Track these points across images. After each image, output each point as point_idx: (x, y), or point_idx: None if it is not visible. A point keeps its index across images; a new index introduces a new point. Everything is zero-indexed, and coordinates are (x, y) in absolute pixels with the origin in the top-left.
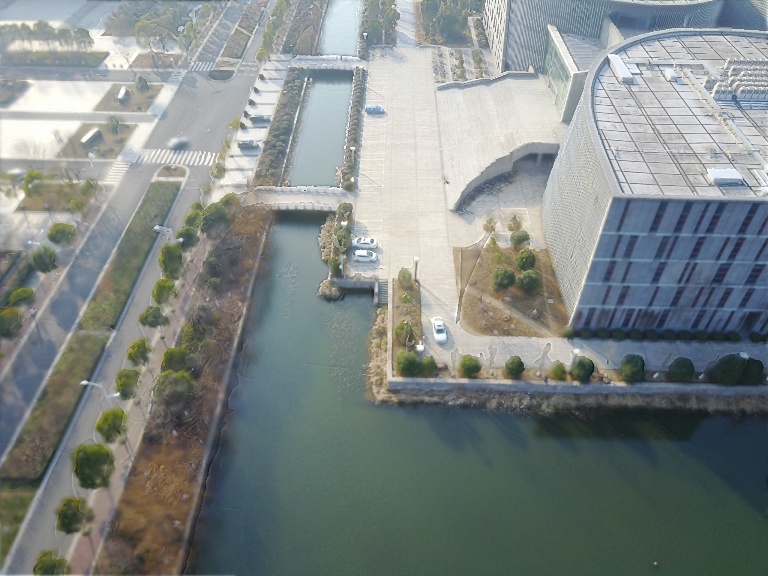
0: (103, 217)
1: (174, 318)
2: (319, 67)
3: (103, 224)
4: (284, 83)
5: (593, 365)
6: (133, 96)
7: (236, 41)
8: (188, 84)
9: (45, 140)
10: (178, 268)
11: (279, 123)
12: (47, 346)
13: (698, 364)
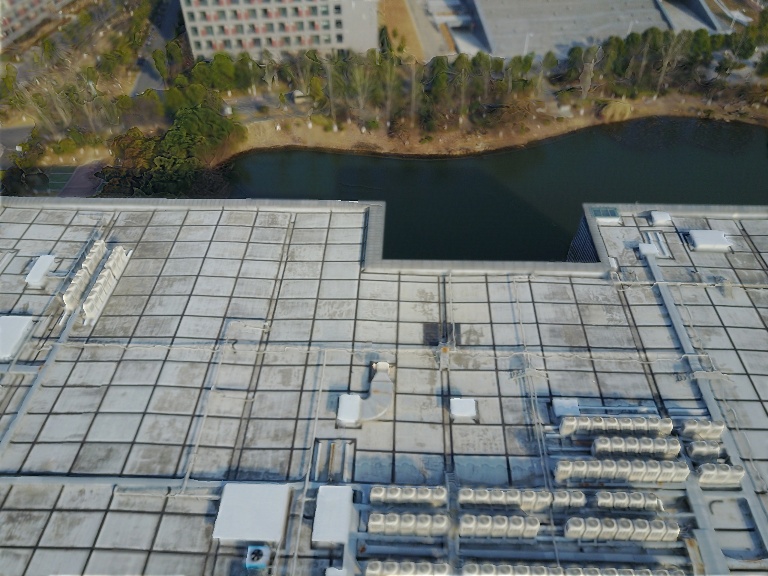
0: None
1: None
2: None
3: None
4: None
5: None
6: None
7: None
8: None
9: None
10: None
11: None
12: None
13: None
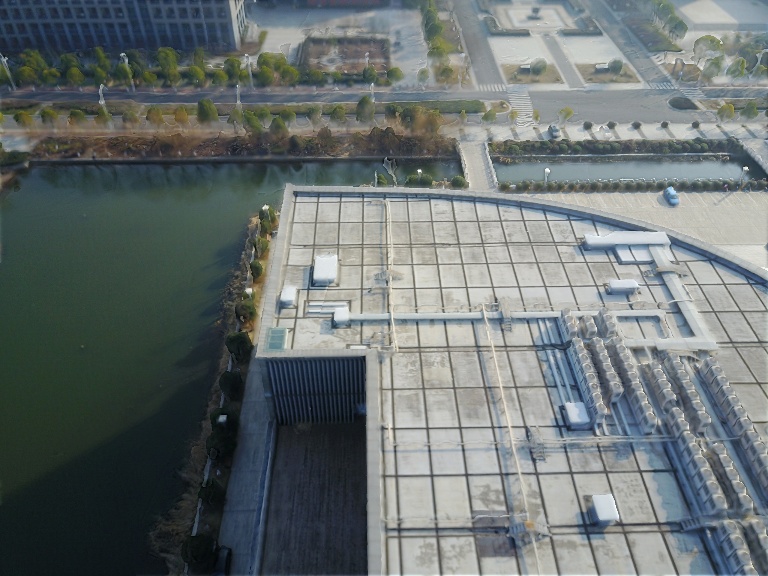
0: (433, 92)
1: (332, 133)
2: (755, 156)
3: (426, 94)
4: (694, 138)
5: (241, 309)
6: (609, 73)
7: (766, 100)
8: (649, 92)
9: (521, 56)
10: (363, 115)
11: (604, 143)
12: (309, 99)
13: (251, 415)
